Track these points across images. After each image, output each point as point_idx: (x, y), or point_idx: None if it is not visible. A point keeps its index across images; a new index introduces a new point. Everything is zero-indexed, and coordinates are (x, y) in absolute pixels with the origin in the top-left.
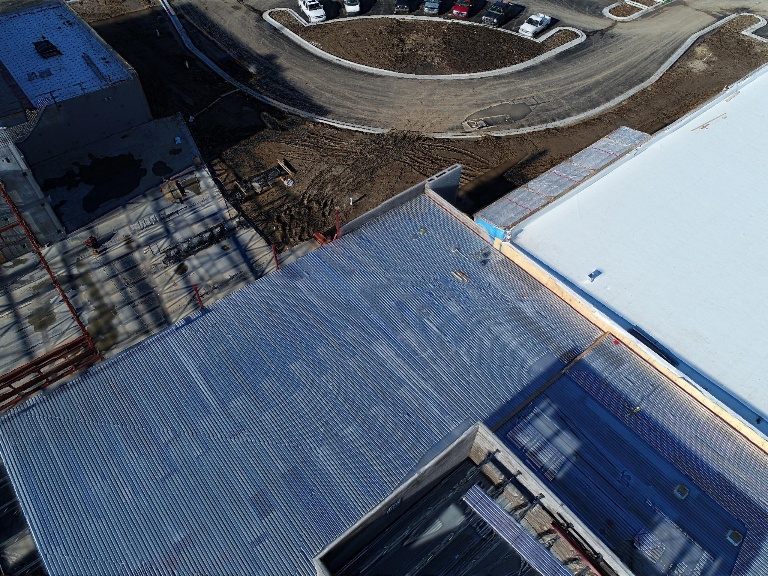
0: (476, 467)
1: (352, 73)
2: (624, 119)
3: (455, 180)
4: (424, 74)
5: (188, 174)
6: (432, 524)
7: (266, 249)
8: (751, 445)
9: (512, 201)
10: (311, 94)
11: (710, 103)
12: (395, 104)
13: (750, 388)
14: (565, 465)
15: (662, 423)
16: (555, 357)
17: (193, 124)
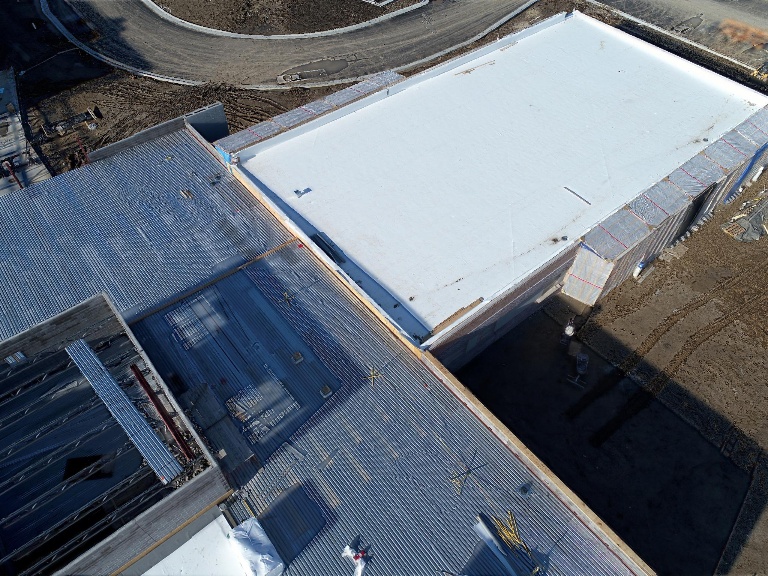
0: (129, 340)
1: (191, 34)
2: None
3: (220, 117)
4: (259, 34)
5: (0, 119)
6: (72, 383)
7: None
8: (380, 324)
9: (251, 131)
10: (145, 52)
11: (477, 50)
12: (221, 60)
13: (401, 281)
14: (205, 338)
15: (309, 307)
16: (242, 258)
17: (22, 77)
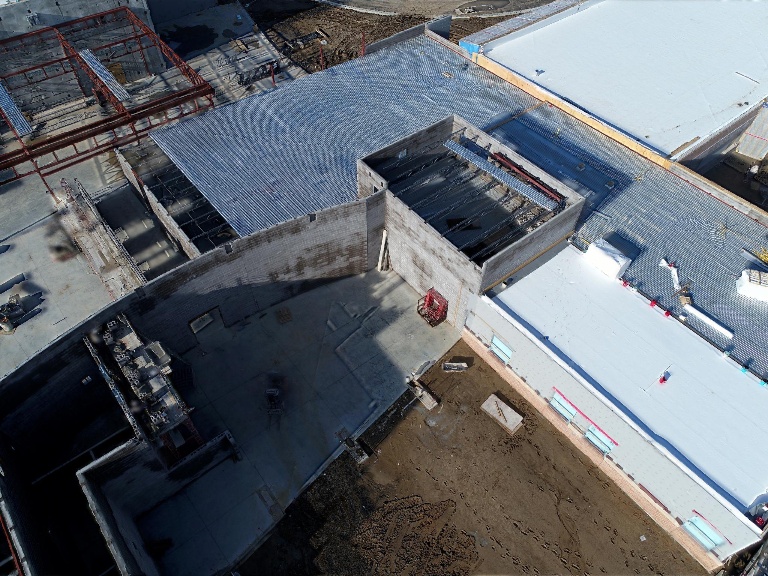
0: (454, 158)
1: None
2: None
3: (447, 27)
4: None
5: (249, 37)
6: (426, 181)
7: None
8: (630, 151)
9: (486, 32)
10: None
11: None
12: None
13: (635, 126)
14: None
15: (575, 141)
16: (509, 113)
17: (249, 8)
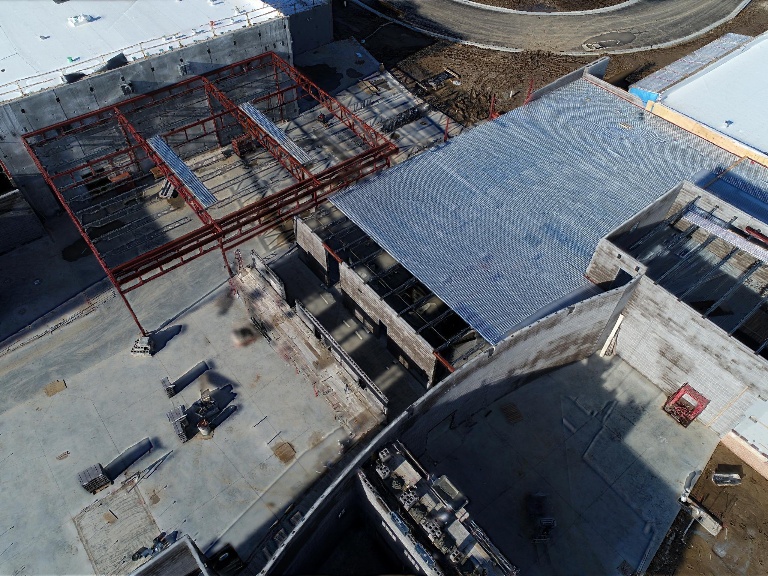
0: (670, 226)
1: (481, 11)
2: None
3: (603, 70)
4: (540, 12)
5: (376, 77)
6: (649, 254)
7: (455, 124)
8: None
9: (657, 77)
10: (452, 25)
11: None
12: (523, 32)
13: None
14: None
15: None
16: (709, 171)
17: (366, 45)
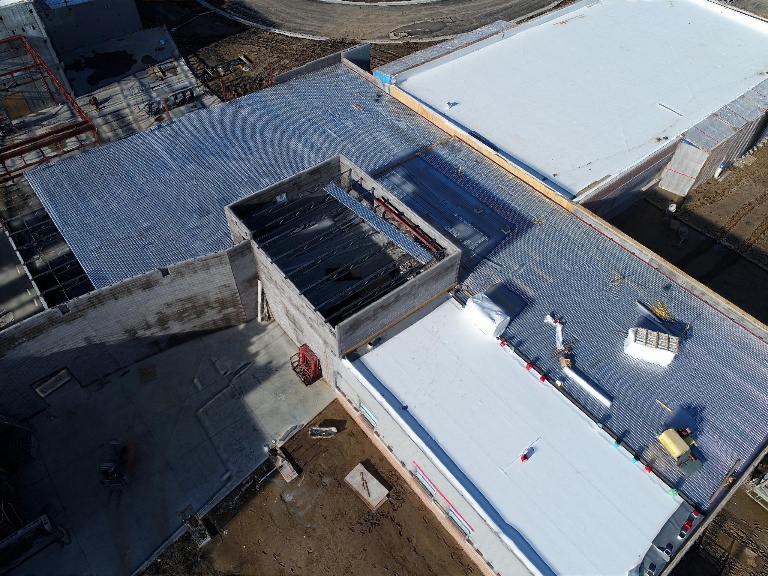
0: None
1: (306, 1)
2: None
3: (366, 55)
4: (365, 2)
5: (169, 63)
6: None
7: None
8: (535, 191)
9: (401, 61)
10: (271, 15)
11: (570, 6)
12: (337, 21)
13: (544, 164)
14: (405, 197)
15: (477, 180)
16: (414, 149)
17: (175, 33)
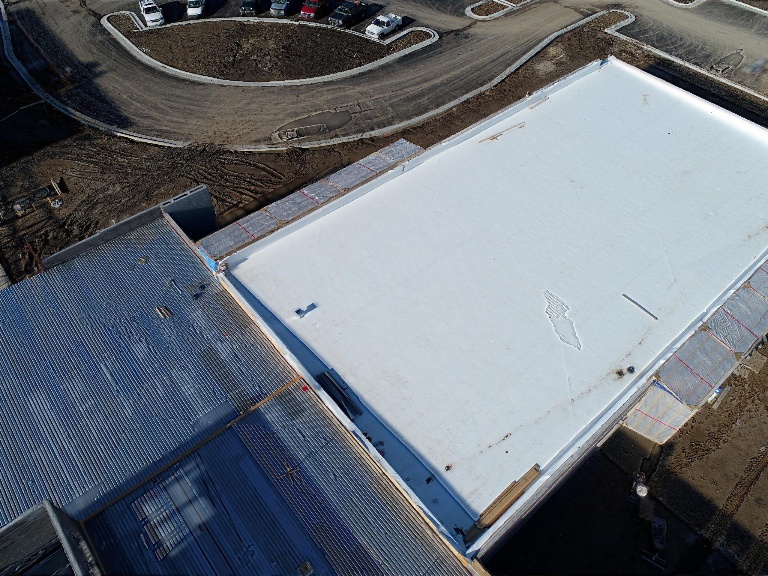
0: None
1: (173, 81)
2: (447, 127)
3: (204, 202)
4: (251, 81)
5: None
6: None
7: (2, 280)
8: (411, 510)
9: (242, 226)
10: (120, 105)
11: (505, 111)
12: (207, 114)
13: (434, 440)
14: (184, 540)
15: (318, 485)
16: (231, 407)
17: None
